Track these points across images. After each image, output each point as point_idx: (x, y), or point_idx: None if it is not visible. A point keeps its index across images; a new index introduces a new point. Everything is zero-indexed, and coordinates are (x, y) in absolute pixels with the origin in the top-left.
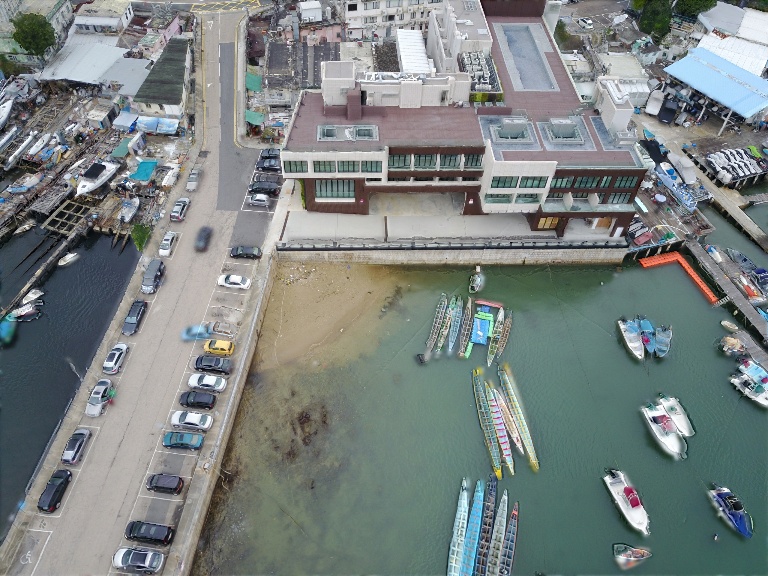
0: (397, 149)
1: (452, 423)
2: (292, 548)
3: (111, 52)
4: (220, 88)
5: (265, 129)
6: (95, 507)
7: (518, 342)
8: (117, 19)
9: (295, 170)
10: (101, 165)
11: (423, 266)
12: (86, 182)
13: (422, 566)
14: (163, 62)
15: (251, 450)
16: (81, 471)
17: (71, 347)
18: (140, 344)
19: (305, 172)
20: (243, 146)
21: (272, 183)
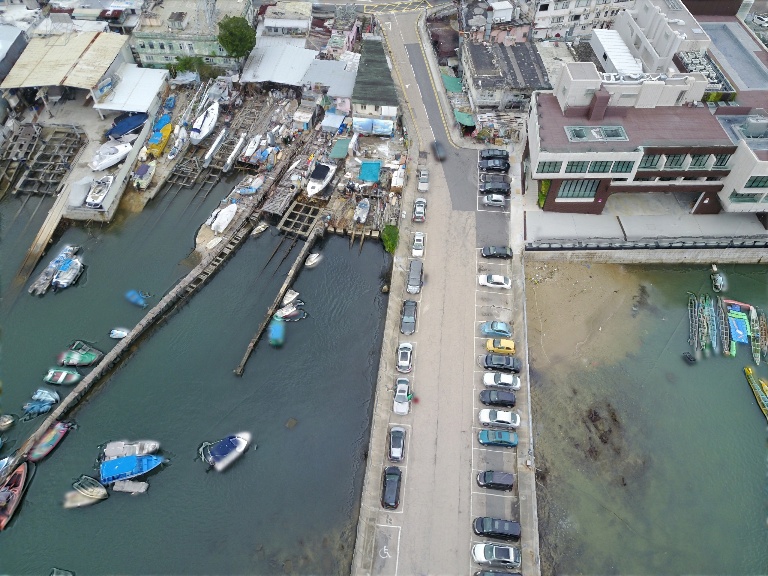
0: (650, 149)
1: (740, 421)
2: (623, 544)
3: (302, 54)
4: (419, 89)
5: (482, 130)
6: (434, 503)
7: None
8: (306, 21)
9: (547, 171)
10: (325, 166)
11: (659, 265)
12: (314, 183)
13: (756, 562)
14: (366, 64)
15: (552, 447)
16: (408, 468)
17: (343, 346)
18: (421, 343)
19: (556, 173)
20: (460, 147)
21: (505, 183)
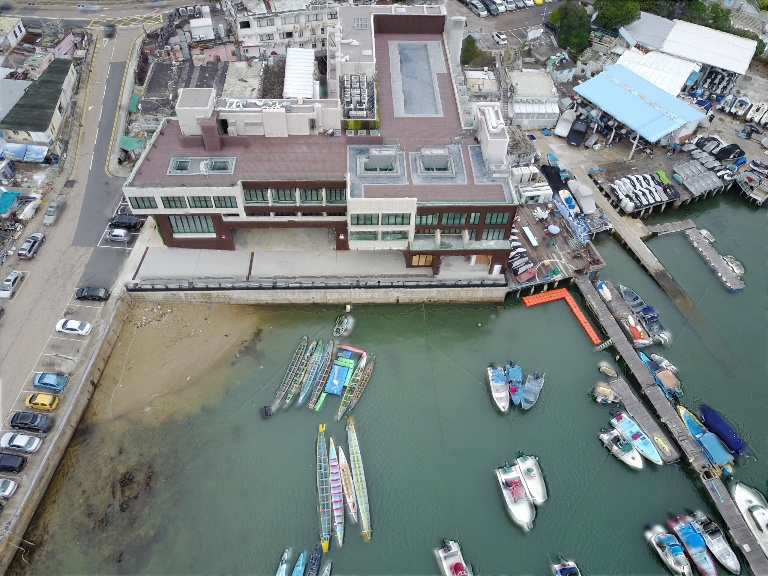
0: (251, 184)
1: (286, 486)
2: None
3: None
4: (101, 111)
5: (136, 157)
6: None
7: (376, 392)
8: (2, 38)
9: (144, 206)
10: None
11: (290, 305)
12: None
13: None
14: (39, 85)
15: (62, 517)
16: None
17: None
18: None
19: (155, 208)
20: (113, 175)
21: (133, 217)
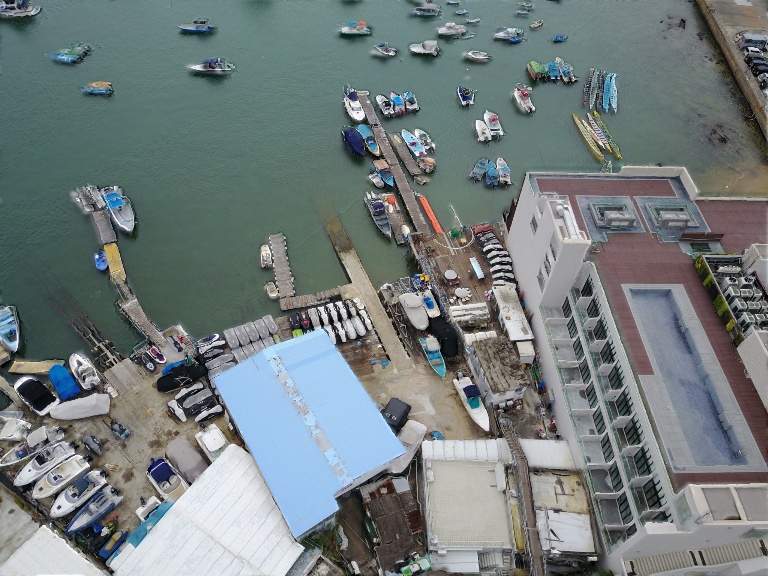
0: None
1: (629, 135)
2: (696, 98)
3: None
4: None
5: None
6: None
7: None
8: None
9: None
10: None
11: None
12: None
13: None
14: None
15: (744, 129)
16: None
17: None
18: None
19: None
20: None
21: None
